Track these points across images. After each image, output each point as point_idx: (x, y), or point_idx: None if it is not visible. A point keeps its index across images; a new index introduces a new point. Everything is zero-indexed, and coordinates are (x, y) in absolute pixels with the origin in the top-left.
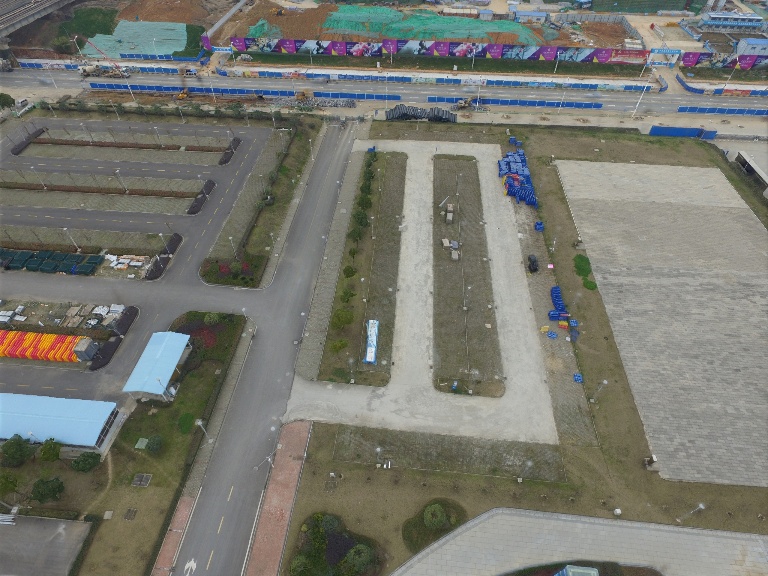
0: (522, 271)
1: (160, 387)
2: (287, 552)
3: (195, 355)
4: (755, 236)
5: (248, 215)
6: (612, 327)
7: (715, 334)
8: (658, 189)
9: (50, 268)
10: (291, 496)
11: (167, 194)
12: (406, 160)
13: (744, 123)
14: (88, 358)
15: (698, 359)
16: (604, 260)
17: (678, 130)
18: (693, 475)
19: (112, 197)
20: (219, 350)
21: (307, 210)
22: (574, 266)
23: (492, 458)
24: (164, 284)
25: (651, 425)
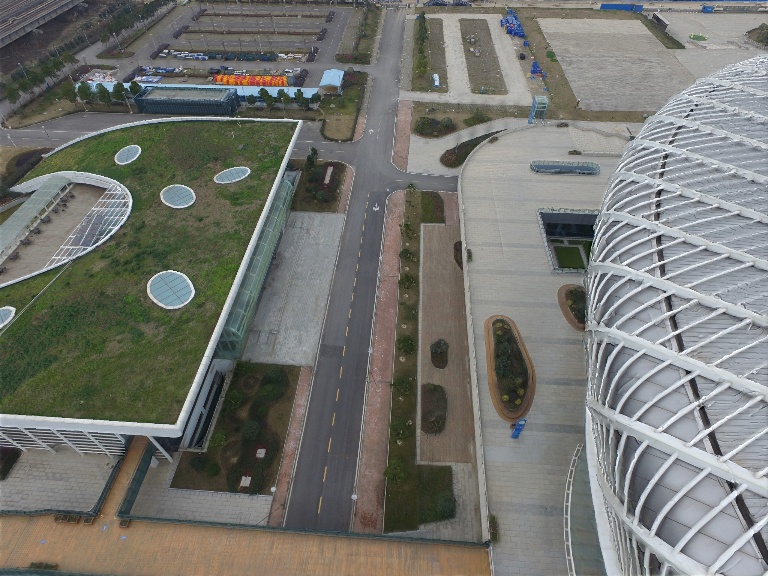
0: (516, 59)
1: (338, 84)
2: (413, 127)
3: (347, 82)
4: (653, 44)
5: (353, 41)
6: (565, 72)
7: (619, 74)
8: (599, 28)
9: (252, 57)
10: (410, 116)
11: (301, 33)
12: (442, 21)
13: (664, 5)
14: (293, 82)
15: (608, 81)
16: (563, 53)
17: (618, 6)
18: (598, 108)
19: (267, 36)
20: (358, 81)
21: (387, 40)
22: (546, 55)
23: (502, 109)
24: (317, 64)
25: (580, 97)
